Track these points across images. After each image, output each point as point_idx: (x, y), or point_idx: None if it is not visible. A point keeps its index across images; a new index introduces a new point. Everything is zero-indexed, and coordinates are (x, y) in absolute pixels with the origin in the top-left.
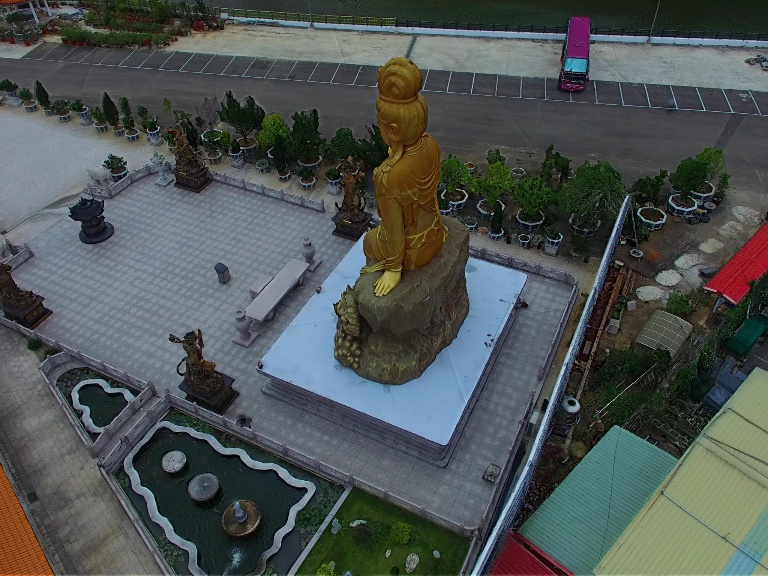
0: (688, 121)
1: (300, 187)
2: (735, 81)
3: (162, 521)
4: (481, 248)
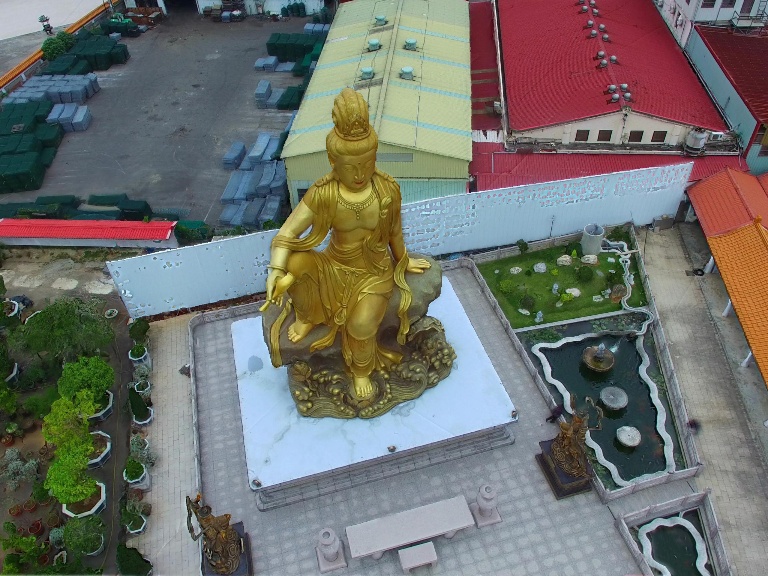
0: None
1: None
2: None
3: (658, 402)
4: None
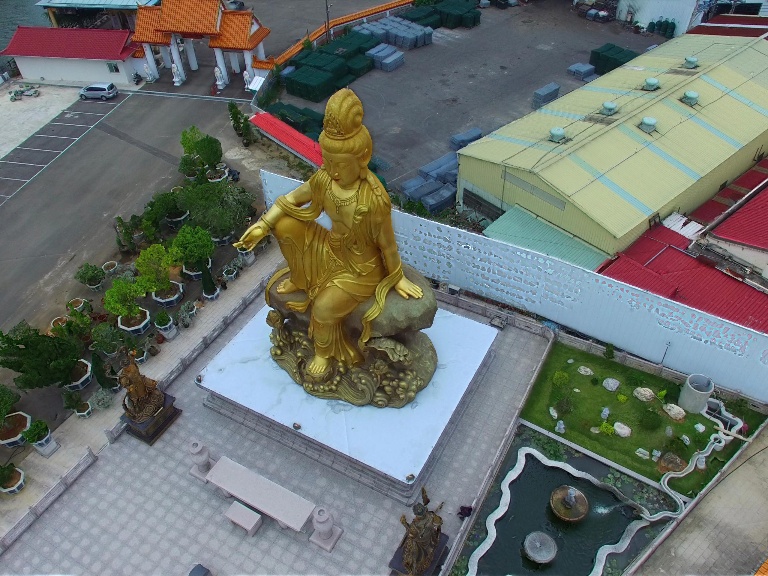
0: (89, 151)
1: (11, 498)
2: (41, 114)
3: None
4: (241, 300)
